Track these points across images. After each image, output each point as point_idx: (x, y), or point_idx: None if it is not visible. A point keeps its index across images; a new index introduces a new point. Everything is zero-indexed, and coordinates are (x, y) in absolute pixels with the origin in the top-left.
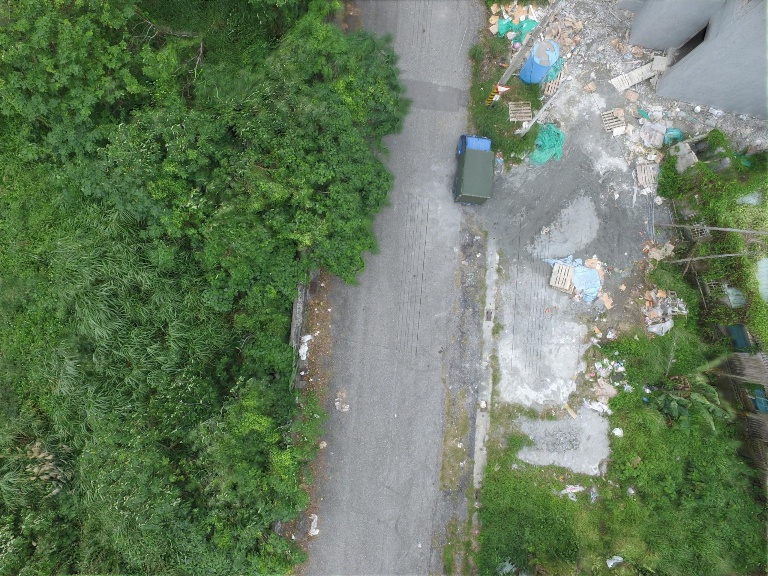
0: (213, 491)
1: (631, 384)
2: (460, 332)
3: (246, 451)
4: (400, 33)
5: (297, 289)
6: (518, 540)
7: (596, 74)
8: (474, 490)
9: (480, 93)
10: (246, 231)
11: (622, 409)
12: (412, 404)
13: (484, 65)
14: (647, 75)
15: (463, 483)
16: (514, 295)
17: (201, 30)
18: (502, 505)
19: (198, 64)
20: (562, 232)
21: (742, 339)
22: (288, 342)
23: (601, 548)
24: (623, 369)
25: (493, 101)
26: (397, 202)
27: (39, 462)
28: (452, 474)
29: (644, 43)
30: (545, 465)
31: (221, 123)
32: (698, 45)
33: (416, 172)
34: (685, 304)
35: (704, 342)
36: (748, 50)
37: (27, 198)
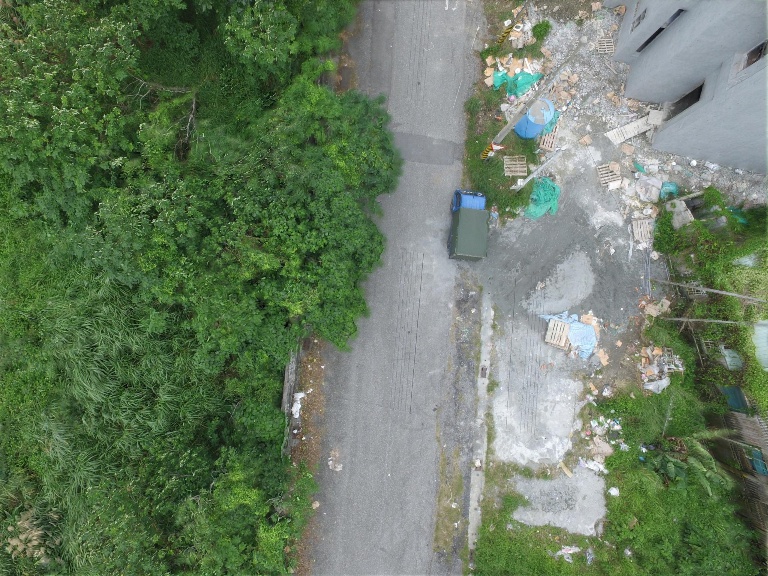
0: (202, 569)
1: (627, 443)
2: (455, 389)
3: (236, 526)
4: (395, 86)
5: (289, 351)
6: None
7: (592, 127)
8: (469, 551)
9: (475, 146)
10: (237, 301)
11: (618, 469)
12: (406, 463)
13: (479, 118)
14: (643, 129)
15: (457, 544)
16: (509, 351)
17: (194, 85)
18: (497, 568)
19: (190, 122)
20: (557, 288)
21: (739, 400)
22: (280, 406)
23: None
24: (619, 427)
25: (488, 156)
26: (391, 257)
27: (27, 528)
28: (446, 535)
29: (640, 96)
30: (540, 525)
31: (212, 190)
32: (694, 104)
33: (410, 227)
34: (681, 361)
35: (701, 399)
36: (744, 115)
37: (17, 255)
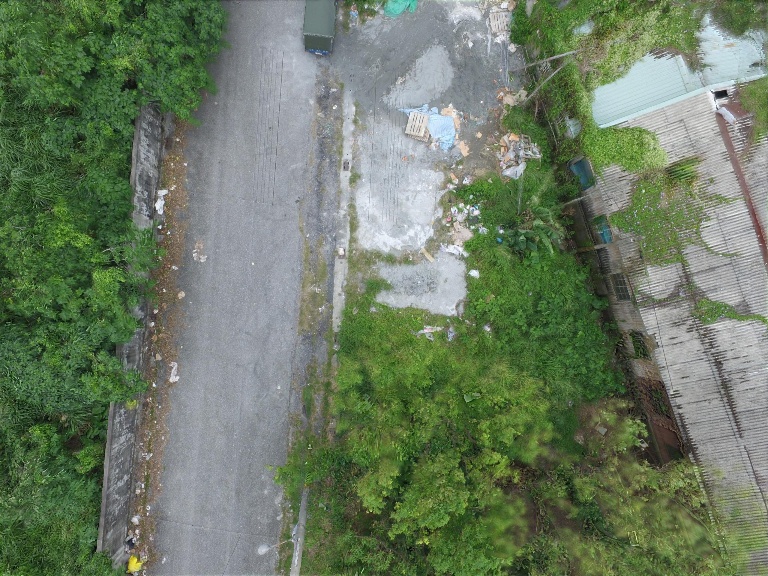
0: (33, 303)
1: (485, 225)
2: (317, 182)
3: (69, 268)
4: None
5: (139, 131)
6: (373, 375)
7: None
8: (333, 334)
9: None
10: (61, 51)
11: (476, 250)
12: (269, 252)
13: None
14: None
15: (322, 327)
16: (371, 145)
17: None
18: (357, 343)
19: None
20: (416, 80)
21: (586, 172)
22: (129, 181)
23: (457, 383)
24: (478, 212)
25: None
26: (251, 56)
27: None
28: (311, 319)
29: None
30: (403, 307)
31: None
32: None
33: (270, 26)
34: (539, 148)
35: (558, 185)
36: None
37: None
